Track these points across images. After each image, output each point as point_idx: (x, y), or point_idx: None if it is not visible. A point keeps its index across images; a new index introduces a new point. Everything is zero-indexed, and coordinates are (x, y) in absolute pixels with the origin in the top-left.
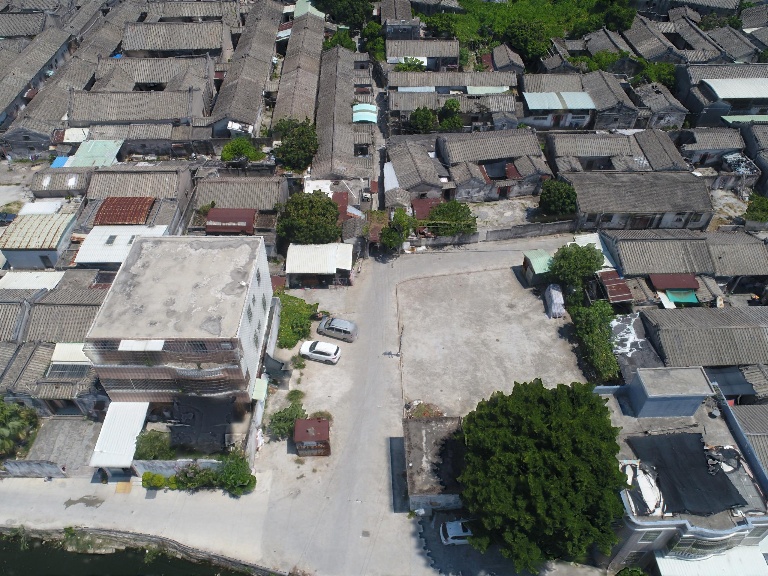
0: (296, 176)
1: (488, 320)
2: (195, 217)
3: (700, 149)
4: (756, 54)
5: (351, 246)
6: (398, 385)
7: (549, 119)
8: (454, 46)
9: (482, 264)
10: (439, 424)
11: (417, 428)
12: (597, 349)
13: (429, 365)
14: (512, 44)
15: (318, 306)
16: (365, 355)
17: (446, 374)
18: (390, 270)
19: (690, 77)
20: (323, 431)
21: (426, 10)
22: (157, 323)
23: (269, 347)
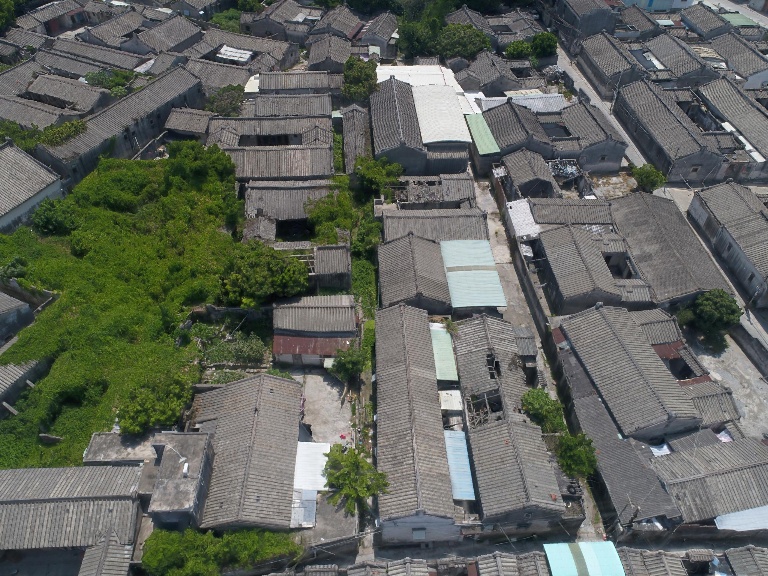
0: None
1: None
2: None
3: None
4: None
5: None
6: None
7: None
8: (275, 384)
9: None
10: None
11: None
12: None
13: None
14: None
15: None
16: None
17: None
18: None
19: (419, 149)
20: None
21: None
22: None
23: None
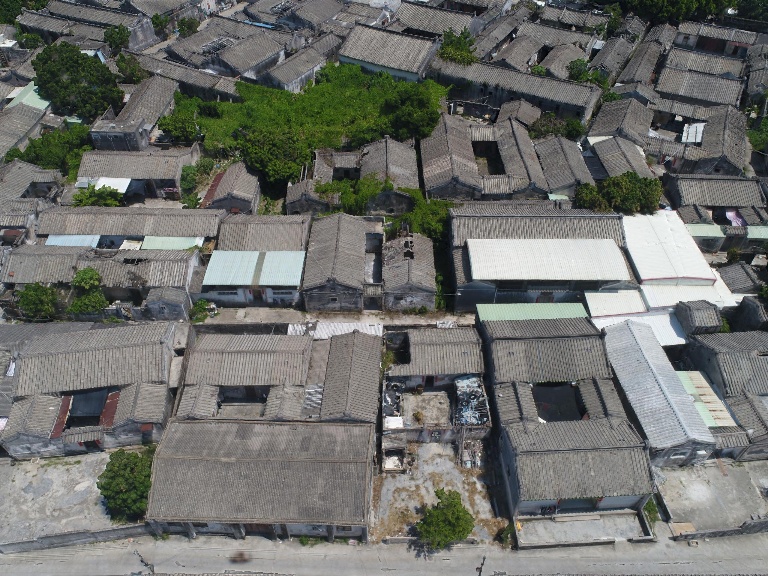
0: None
1: None
2: None
3: (412, 374)
4: (579, 186)
5: None
6: None
7: (241, 294)
8: (172, 163)
9: None
10: None
11: None
12: None
13: None
14: (248, 163)
15: None
16: None
17: None
18: None
19: (452, 235)
20: None
21: (202, 93)
22: None
23: None
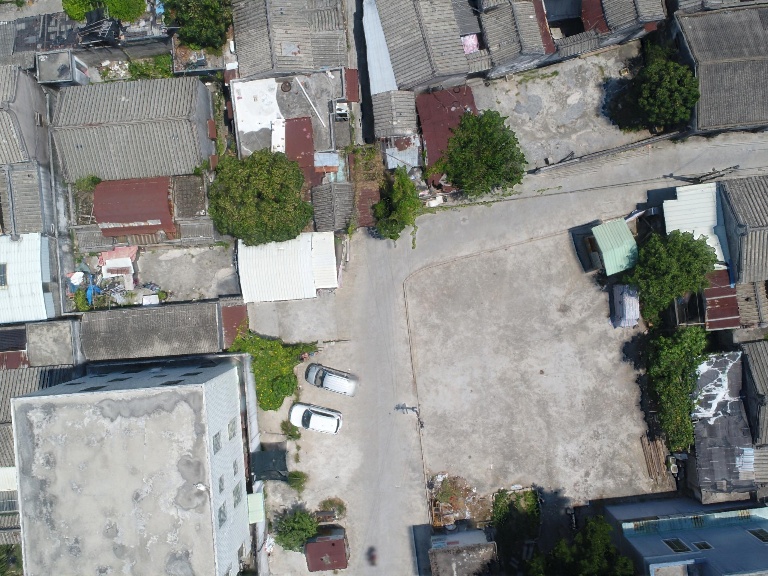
0: (212, 63)
1: (531, 338)
2: (74, 194)
3: None
4: None
5: (331, 235)
6: (417, 455)
7: None
8: None
9: (527, 227)
10: (471, 554)
11: (446, 561)
12: (671, 409)
13: (454, 420)
14: None
15: (299, 328)
16: (373, 412)
17: (475, 432)
18: (392, 253)
19: None
20: (339, 558)
21: None
22: (108, 569)
23: (252, 442)
